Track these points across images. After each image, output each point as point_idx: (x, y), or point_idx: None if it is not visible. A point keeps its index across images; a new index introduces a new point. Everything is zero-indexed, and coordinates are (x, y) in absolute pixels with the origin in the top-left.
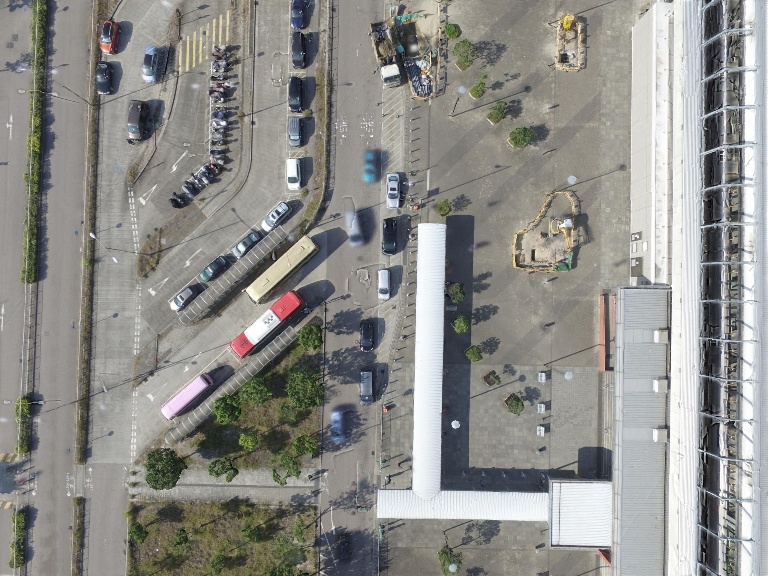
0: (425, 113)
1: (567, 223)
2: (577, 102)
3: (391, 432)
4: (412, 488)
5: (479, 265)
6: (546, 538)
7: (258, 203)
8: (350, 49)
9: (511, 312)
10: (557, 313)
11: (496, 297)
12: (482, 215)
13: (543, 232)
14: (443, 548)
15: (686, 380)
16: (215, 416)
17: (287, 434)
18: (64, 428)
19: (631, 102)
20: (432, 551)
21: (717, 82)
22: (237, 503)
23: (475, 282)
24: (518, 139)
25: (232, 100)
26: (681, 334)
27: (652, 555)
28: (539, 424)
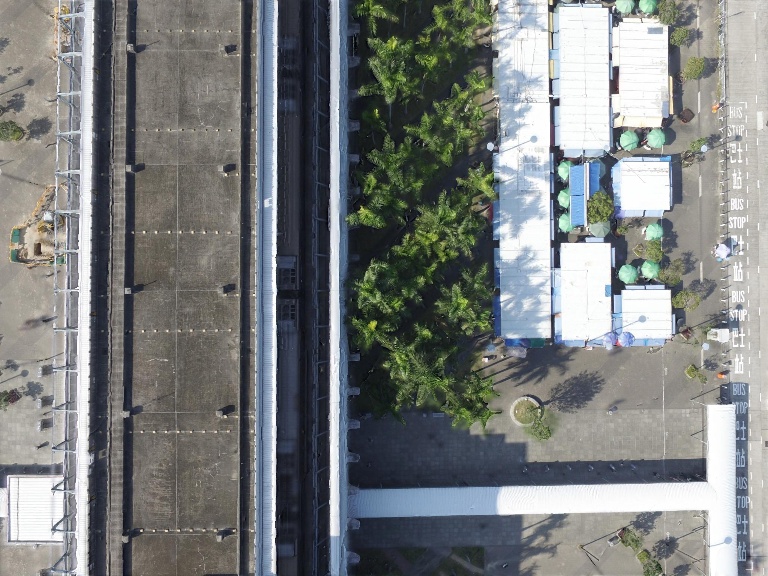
0: None
1: (46, 216)
2: None
3: None
4: None
5: None
6: None
7: None
8: None
9: (14, 307)
10: (60, 307)
11: None
12: None
13: (46, 226)
14: None
15: None
16: None
17: None
18: None
19: None
20: None
21: None
22: None
23: None
24: None
25: None
26: None
27: None
28: (41, 419)
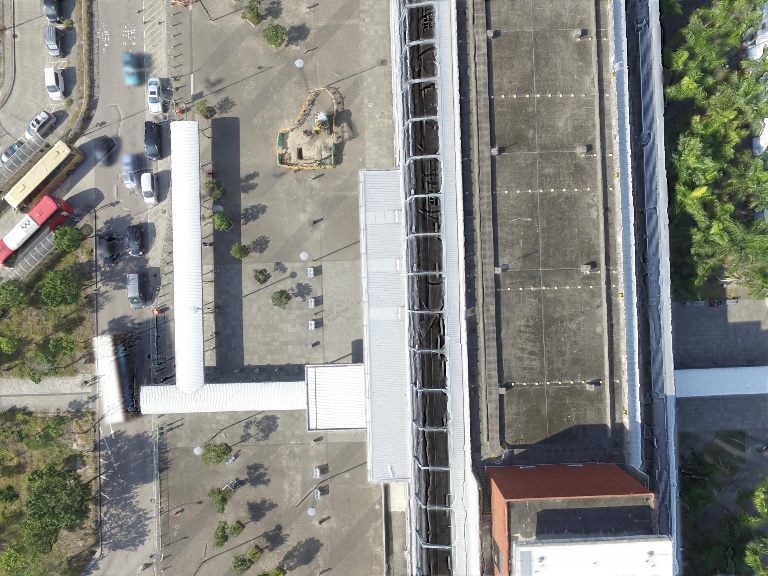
0: (186, 18)
1: (321, 116)
2: (336, 0)
3: (166, 335)
4: (176, 383)
5: (246, 166)
6: None
7: (23, 115)
8: None
9: (280, 210)
10: (325, 209)
11: (264, 196)
12: (247, 116)
13: (308, 130)
14: None
15: None
16: None
17: None
18: None
19: None
20: None
21: None
22: (14, 412)
23: (243, 183)
24: (269, 35)
25: None
26: (401, 204)
27: (404, 432)
28: (312, 319)
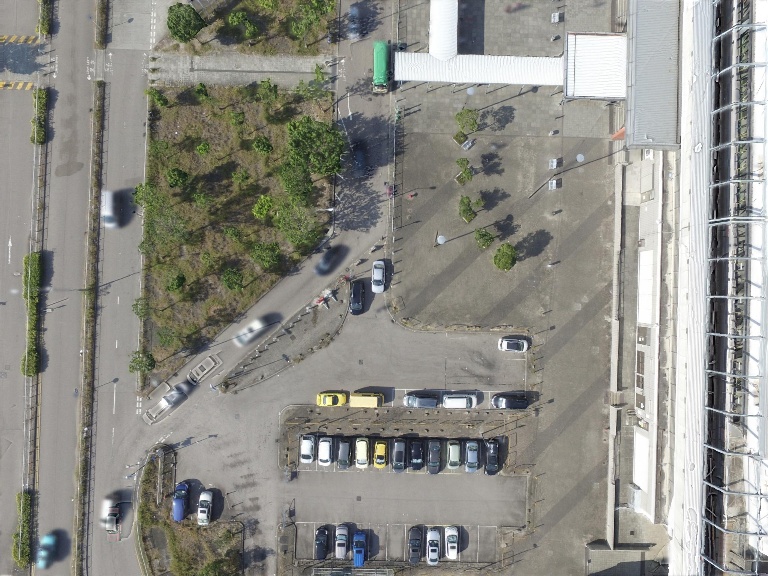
0: None
1: None
2: None
3: (407, 21)
4: (429, 52)
5: None
6: (560, 125)
7: None
8: None
9: None
10: None
11: None
12: None
13: None
14: (458, 132)
15: None
16: (234, 3)
17: None
18: (84, 13)
19: None
20: (447, 137)
21: None
22: (255, 87)
23: None
24: None
25: None
26: None
27: (666, 97)
28: None
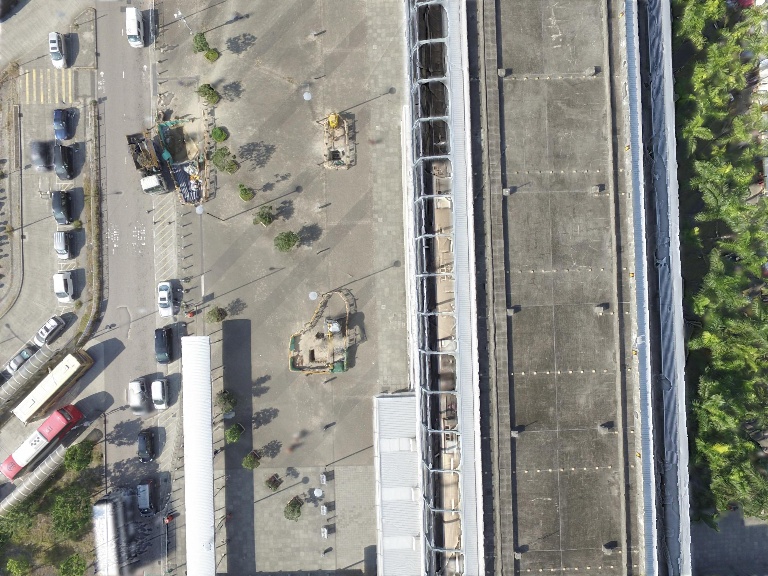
0: (196, 218)
1: (334, 327)
2: (349, 200)
3: (176, 541)
4: None
5: (257, 369)
6: None
7: (32, 318)
8: (118, 157)
9: (291, 414)
10: (337, 413)
11: (276, 400)
12: (258, 318)
13: (320, 332)
14: None
15: (421, 498)
16: None
17: (71, 549)
18: None
19: (402, 197)
20: None
21: (436, 199)
22: None
23: (254, 386)
24: (281, 245)
25: (0, 215)
26: (417, 451)
27: None
28: (324, 525)
